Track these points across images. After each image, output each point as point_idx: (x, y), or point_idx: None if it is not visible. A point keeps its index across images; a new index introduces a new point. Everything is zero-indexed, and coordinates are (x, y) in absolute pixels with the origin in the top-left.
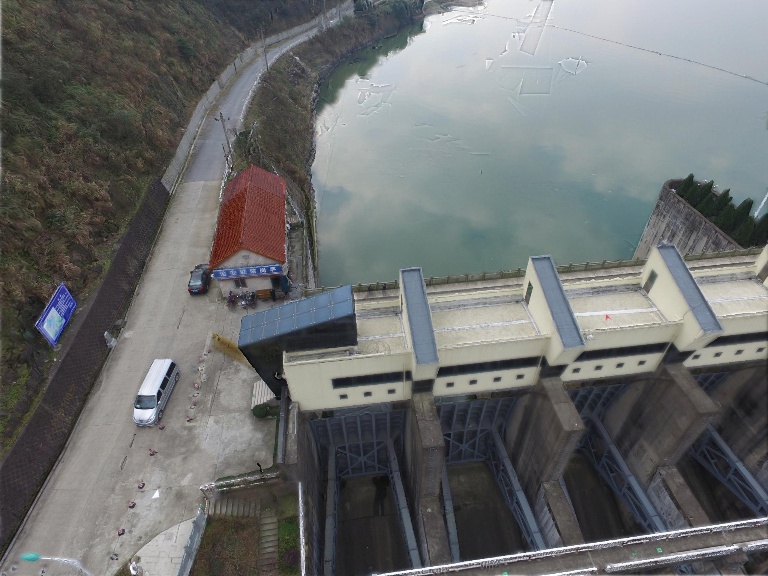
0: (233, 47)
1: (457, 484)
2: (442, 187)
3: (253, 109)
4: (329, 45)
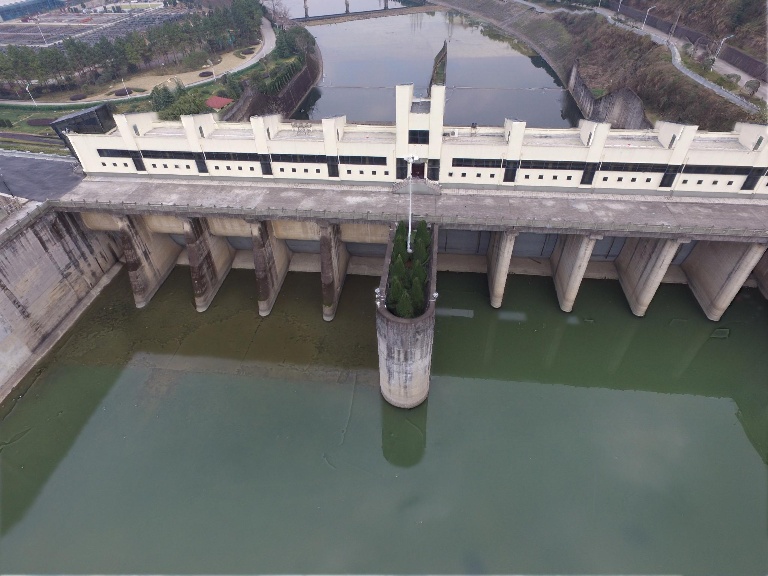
0: None
1: None
2: None
3: None
4: None
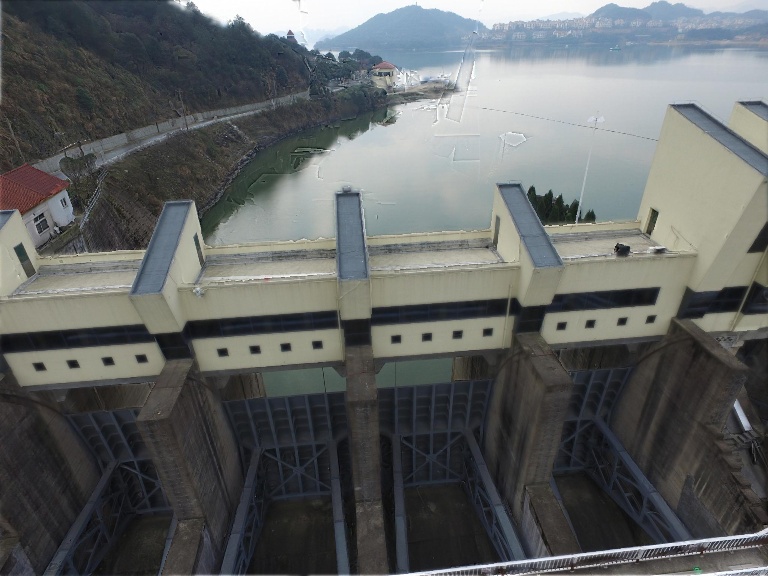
0: (166, 113)
1: (155, 541)
2: (330, 230)
3: (141, 152)
4: (277, 120)
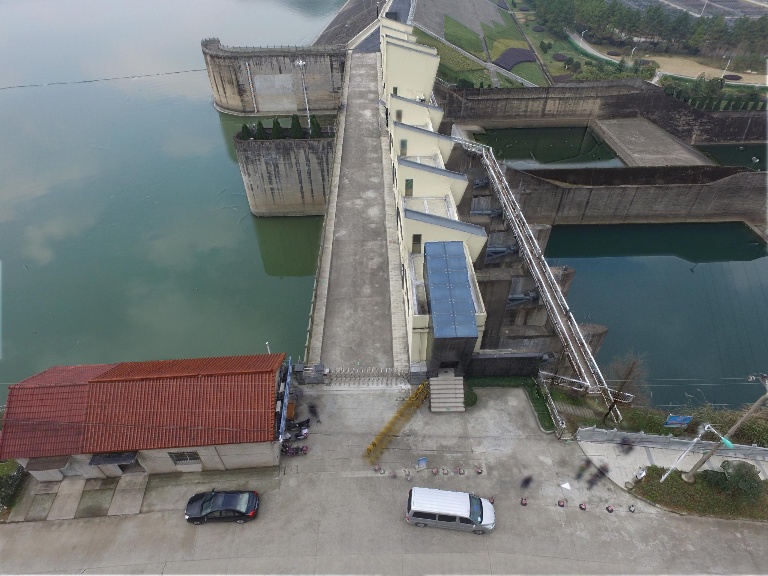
0: None
1: None
2: (20, 307)
3: None
4: None
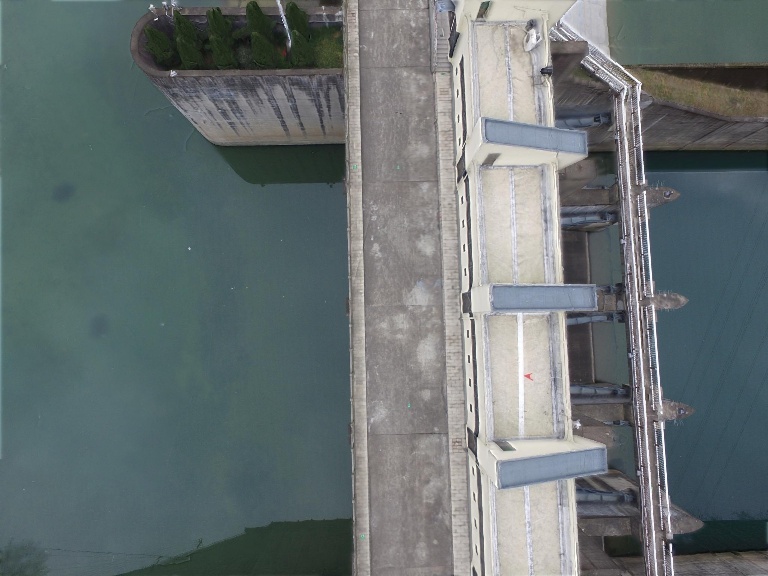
0: None
1: None
2: None
3: None
4: None
